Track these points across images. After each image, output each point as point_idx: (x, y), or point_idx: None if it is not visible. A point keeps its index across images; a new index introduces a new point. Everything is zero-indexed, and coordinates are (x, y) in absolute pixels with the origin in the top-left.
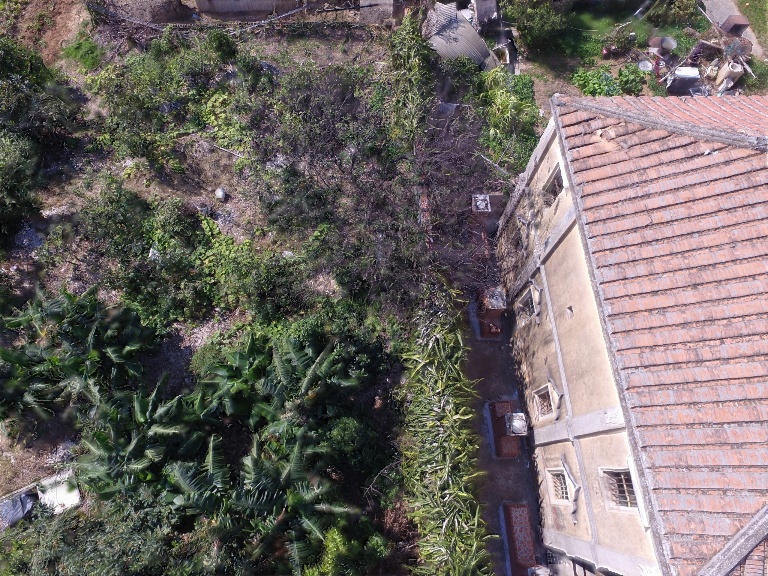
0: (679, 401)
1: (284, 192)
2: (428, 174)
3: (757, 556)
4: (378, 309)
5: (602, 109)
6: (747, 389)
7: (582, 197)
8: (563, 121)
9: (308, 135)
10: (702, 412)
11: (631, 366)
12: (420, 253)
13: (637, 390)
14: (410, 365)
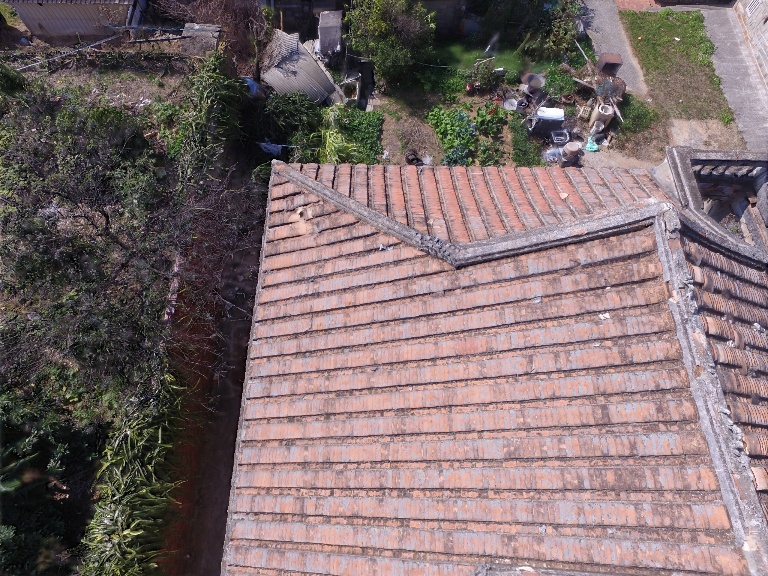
0: (269, 565)
1: (25, 249)
2: (174, 236)
3: None
4: (121, 383)
5: (305, 183)
6: (332, 562)
7: (263, 288)
8: (271, 193)
9: (80, 181)
10: None
11: (242, 511)
12: (149, 327)
13: (239, 543)
14: (105, 461)
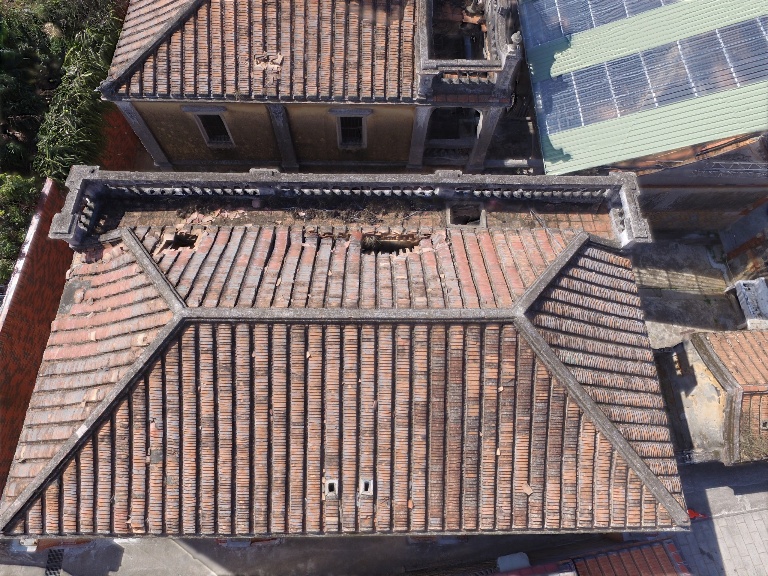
0: (147, 2)
1: None
2: None
3: (149, 65)
4: None
5: None
6: None
7: None
8: None
9: None
10: (154, 4)
11: None
12: None
13: None
14: None
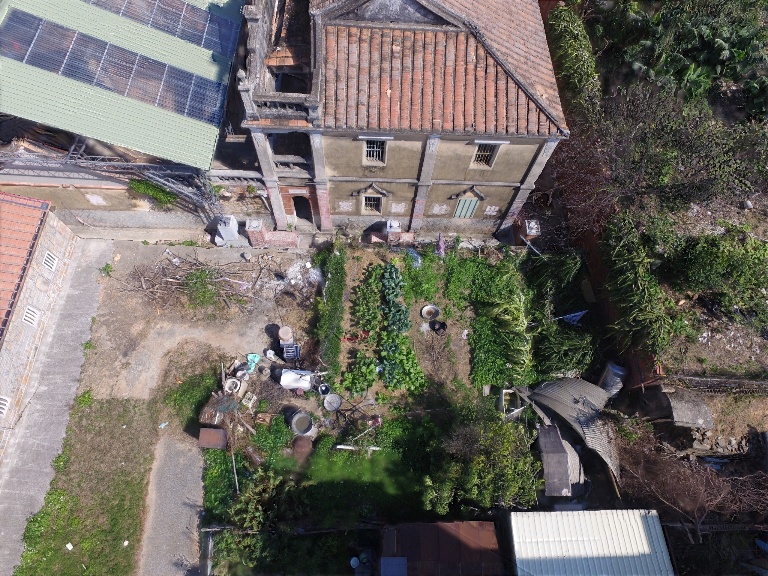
0: None
1: None
2: None
3: None
4: None
5: None
6: None
7: None
8: None
9: None
10: None
11: None
12: None
13: None
14: None
